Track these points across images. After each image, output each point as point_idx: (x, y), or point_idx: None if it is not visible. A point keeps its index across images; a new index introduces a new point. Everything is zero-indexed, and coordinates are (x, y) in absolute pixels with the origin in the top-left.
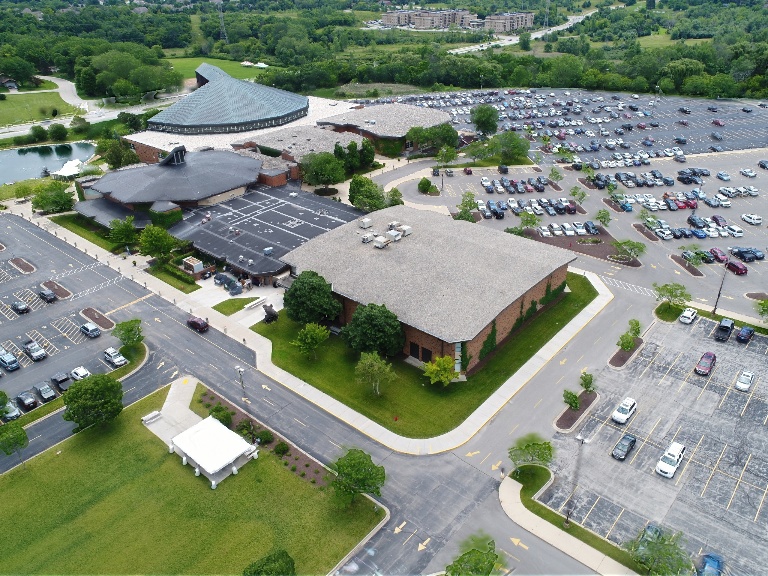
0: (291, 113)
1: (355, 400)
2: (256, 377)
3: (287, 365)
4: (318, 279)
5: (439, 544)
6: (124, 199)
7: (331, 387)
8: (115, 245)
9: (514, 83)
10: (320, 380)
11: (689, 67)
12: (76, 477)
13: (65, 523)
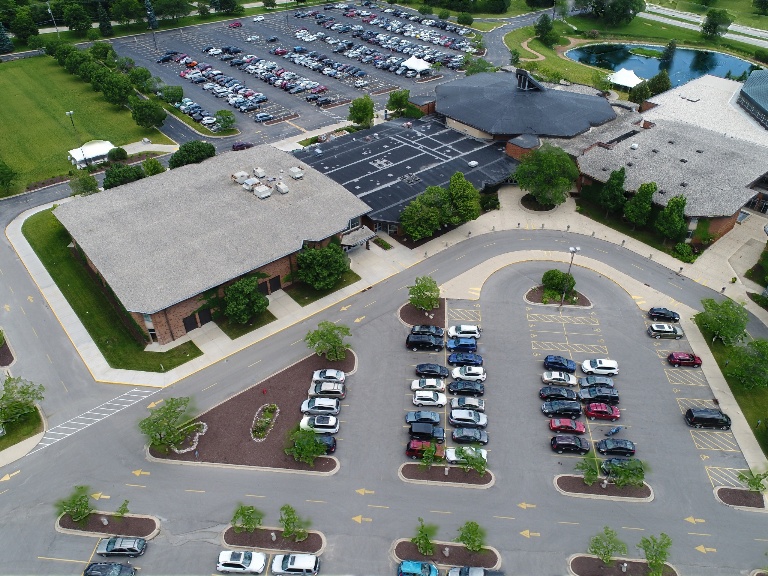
0: None
1: None
2: None
3: None
4: (194, 150)
5: None
6: (442, 84)
7: None
8: None
9: None
10: None
11: None
12: None
13: None
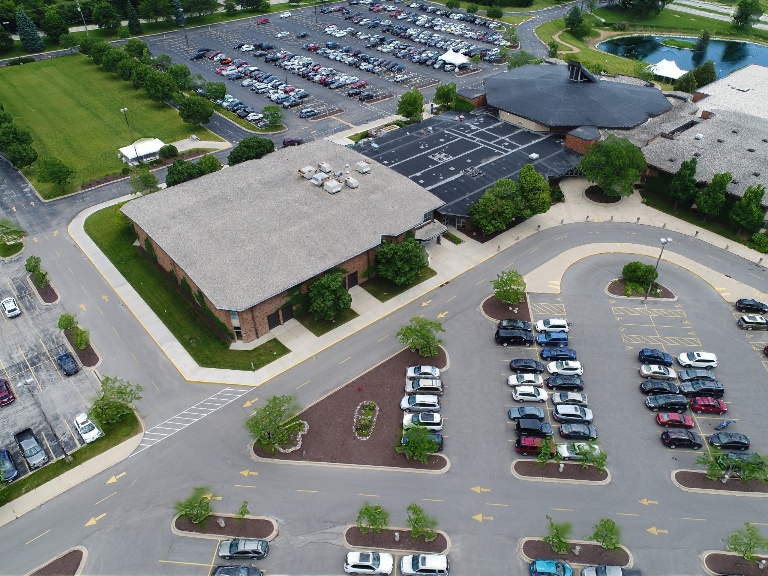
0: None
1: None
2: None
3: None
4: (254, 146)
5: (8, 213)
6: (489, 77)
7: None
8: (451, 105)
9: None
10: None
11: None
12: (162, 127)
13: (132, 128)
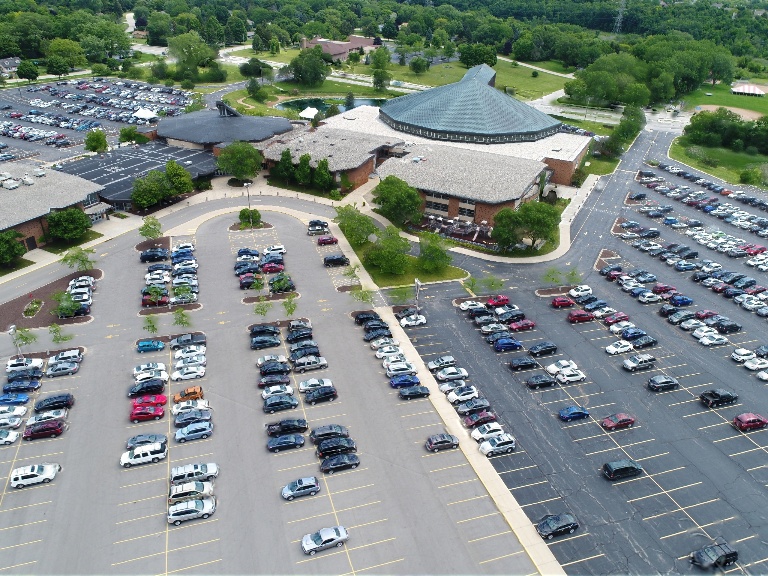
0: (456, 132)
1: None
2: None
3: None
4: None
5: None
6: None
7: None
8: None
9: None
10: None
11: None
12: None
13: None
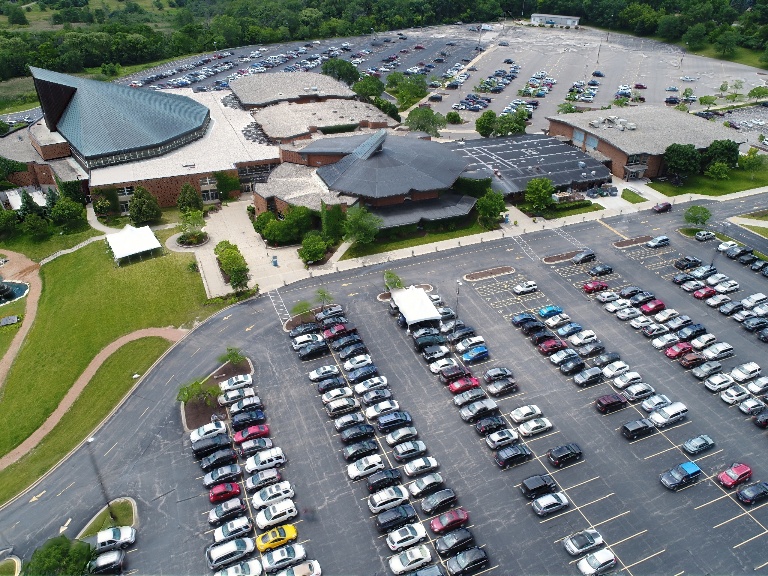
0: None
1: (759, 184)
2: (732, 202)
3: (720, 193)
4: None
5: None
6: (443, 185)
7: (746, 187)
8: (479, 226)
9: (184, 50)
10: (738, 188)
11: (317, 15)
12: None
13: None
